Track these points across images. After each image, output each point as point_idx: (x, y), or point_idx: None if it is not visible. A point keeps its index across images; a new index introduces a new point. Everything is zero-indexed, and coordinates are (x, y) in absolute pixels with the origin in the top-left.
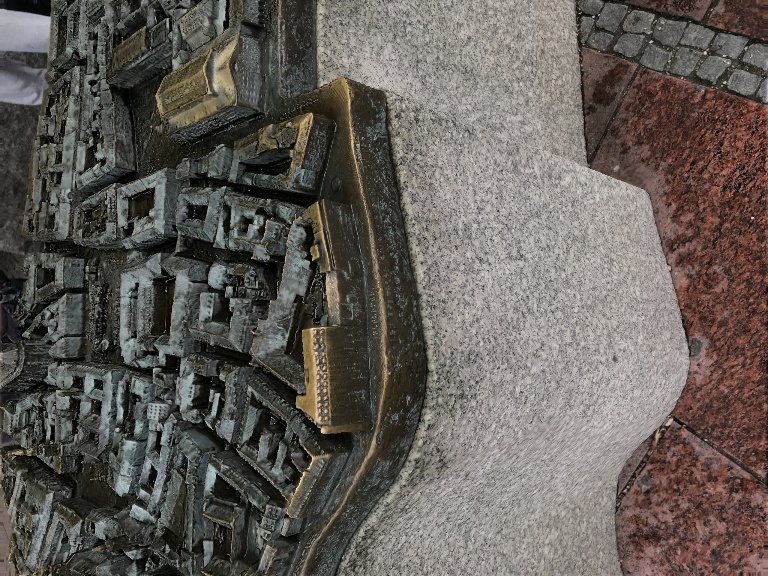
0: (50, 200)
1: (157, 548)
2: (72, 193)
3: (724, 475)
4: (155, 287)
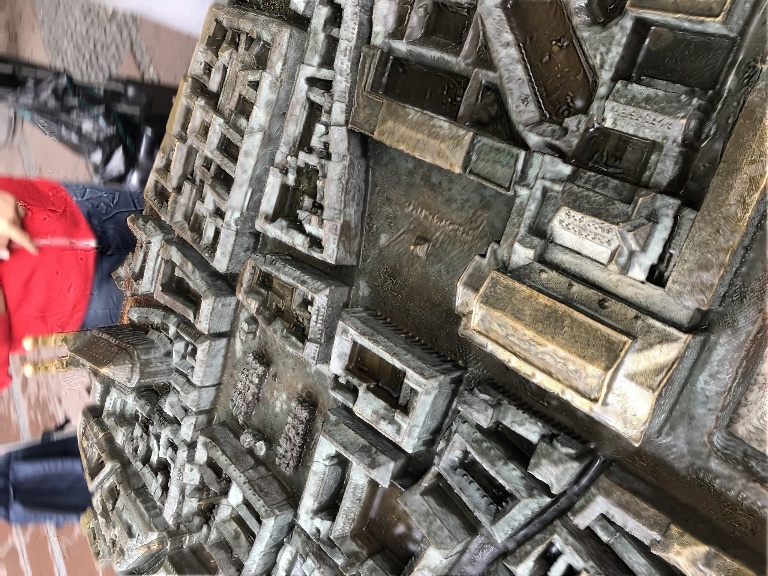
0: None
1: None
2: (241, 218)
3: None
4: (369, 484)
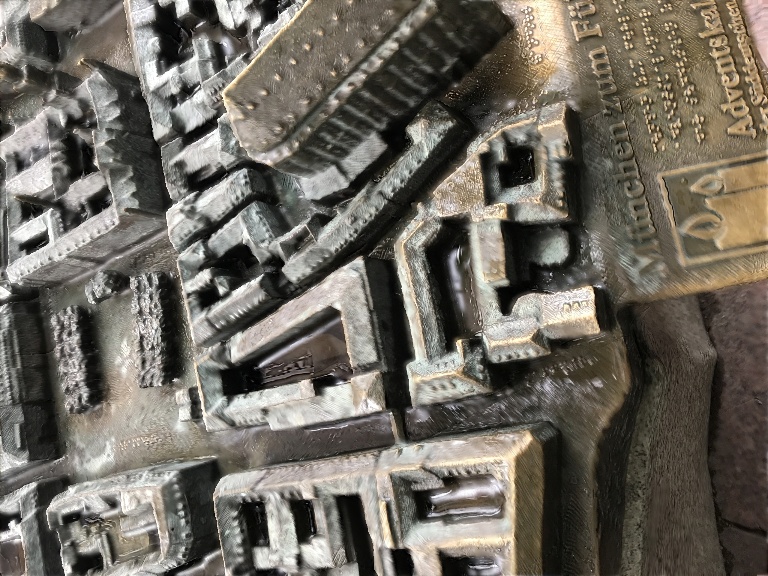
0: None
1: None
2: None
3: None
4: None
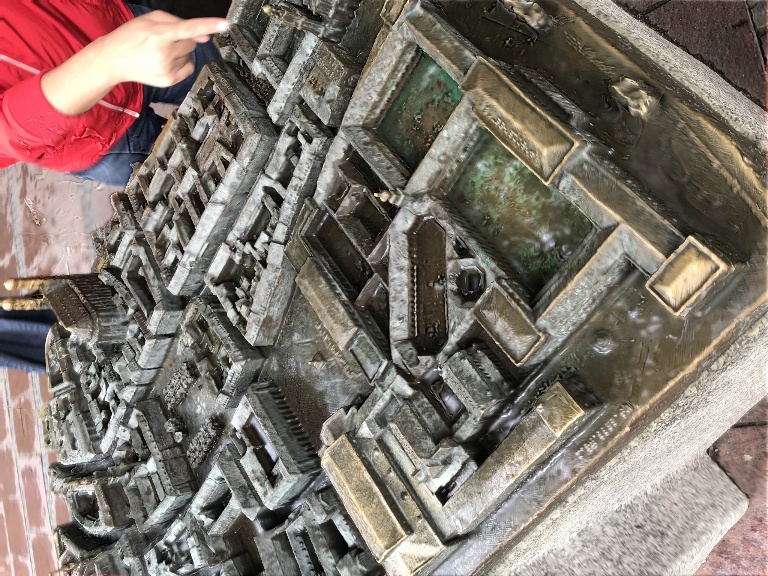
0: None
1: None
2: (196, 261)
3: None
4: None
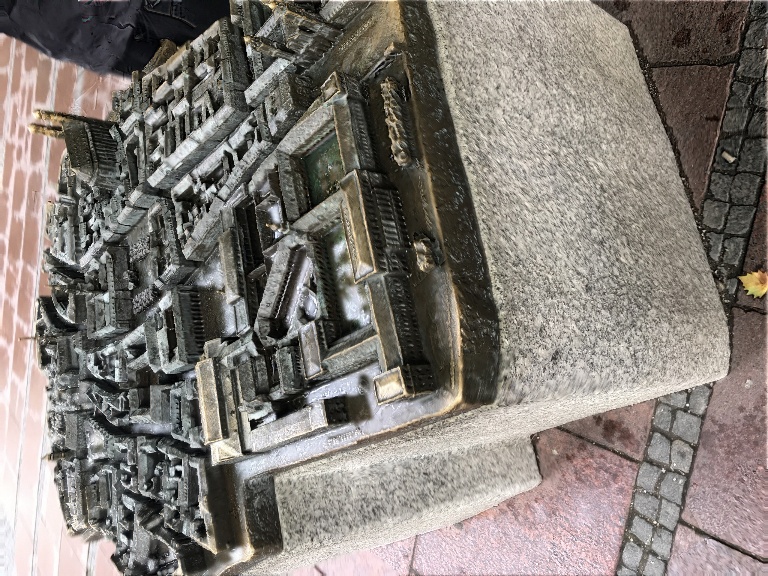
0: (159, 139)
1: (85, 428)
2: (172, 171)
3: (405, 547)
4: None
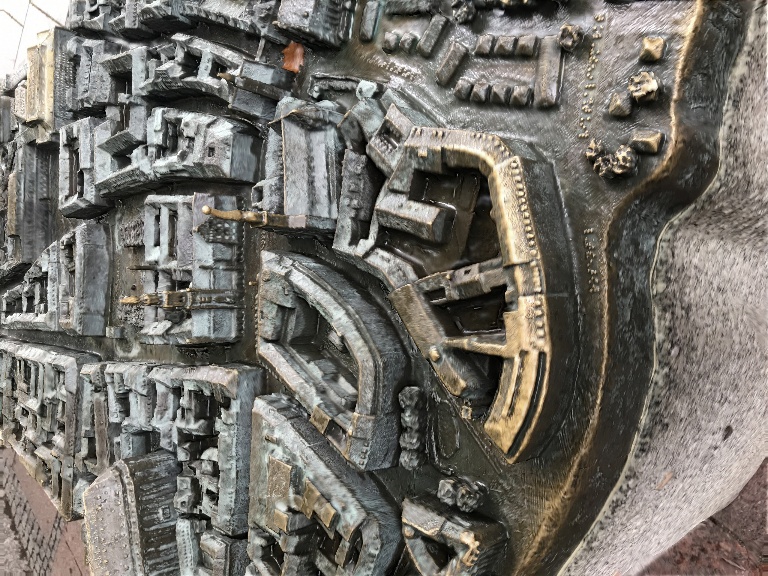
0: None
1: None
2: None
3: None
4: None
